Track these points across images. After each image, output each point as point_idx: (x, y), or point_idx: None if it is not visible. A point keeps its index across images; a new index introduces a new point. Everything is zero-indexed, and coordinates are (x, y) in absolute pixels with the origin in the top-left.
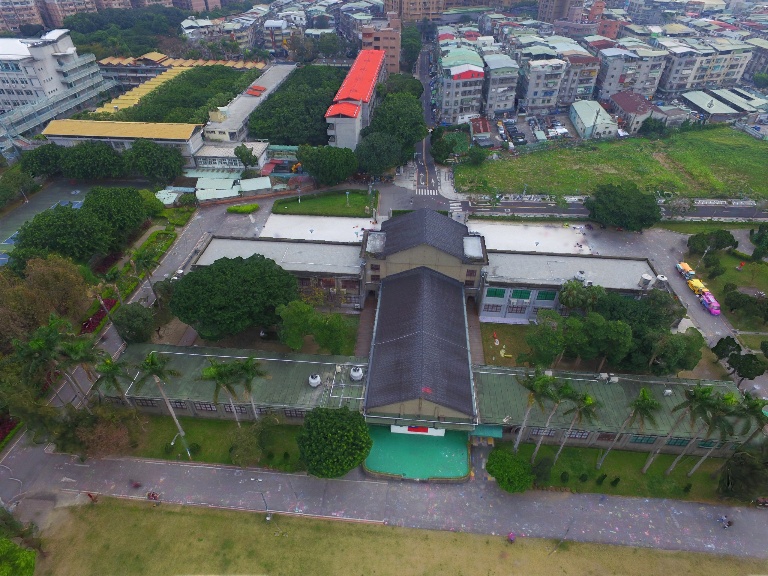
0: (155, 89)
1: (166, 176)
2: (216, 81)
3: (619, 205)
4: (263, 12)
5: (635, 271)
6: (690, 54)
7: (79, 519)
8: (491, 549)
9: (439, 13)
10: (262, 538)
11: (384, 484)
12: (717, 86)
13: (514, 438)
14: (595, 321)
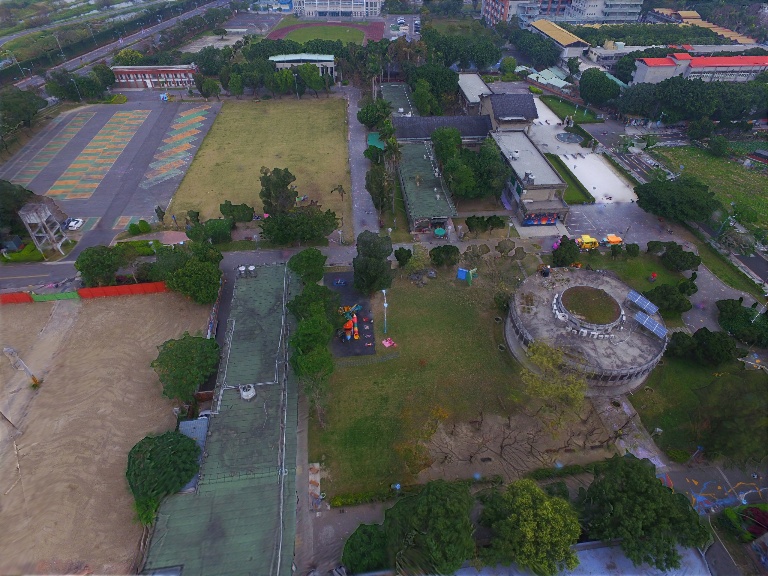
0: (623, 25)
1: (537, 61)
2: None
3: (660, 185)
4: None
5: (545, 179)
6: None
7: (339, 99)
8: None
9: None
10: None
11: (365, 139)
12: None
13: None
14: (448, 133)
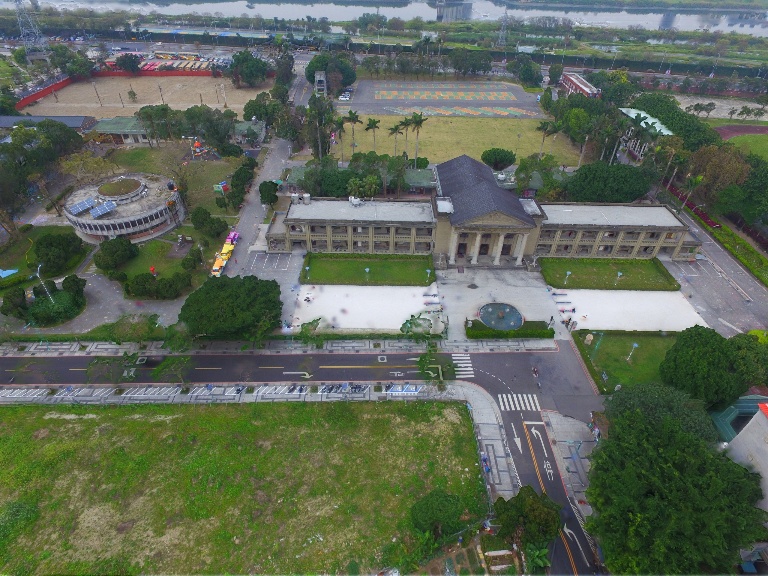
0: None
1: None
2: None
3: None
4: None
5: (304, 213)
6: None
7: None
8: None
9: None
10: None
11: None
12: None
13: None
14: None
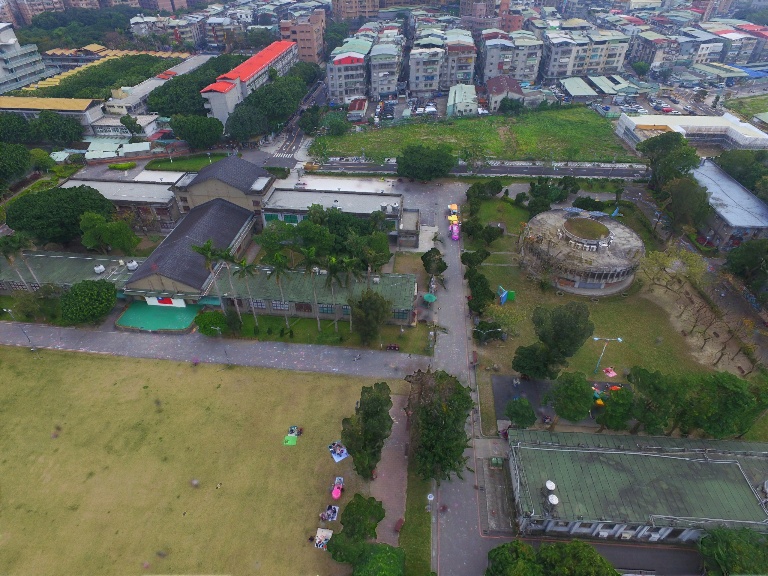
0: (77, 73)
1: (64, 140)
2: (135, 67)
3: (414, 160)
4: (216, 11)
5: None
6: (566, 44)
7: None
8: (179, 368)
9: (375, 11)
10: (23, 360)
11: (127, 334)
12: (599, 74)
13: (239, 310)
14: (299, 224)
